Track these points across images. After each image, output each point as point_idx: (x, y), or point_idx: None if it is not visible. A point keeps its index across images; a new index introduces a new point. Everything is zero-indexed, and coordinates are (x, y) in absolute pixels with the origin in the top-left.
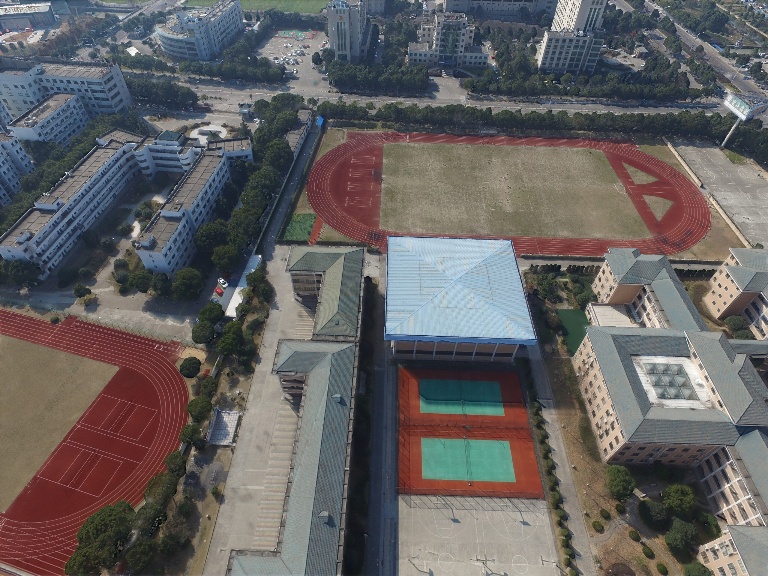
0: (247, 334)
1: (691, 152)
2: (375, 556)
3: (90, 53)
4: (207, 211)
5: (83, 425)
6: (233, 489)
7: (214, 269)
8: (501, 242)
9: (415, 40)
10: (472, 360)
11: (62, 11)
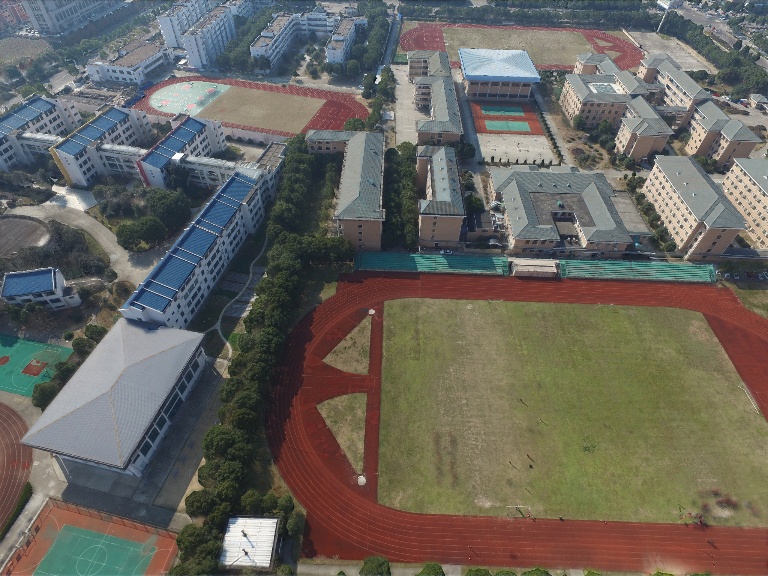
0: None
1: (637, 34)
2: None
3: None
4: None
5: (319, 114)
6: (400, 130)
7: None
8: (521, 51)
9: None
10: (507, 100)
11: None
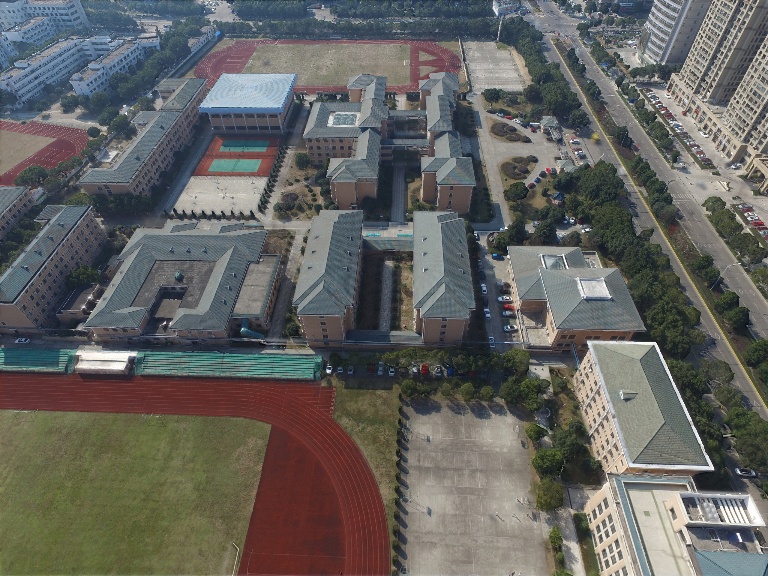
0: (133, 125)
1: (473, 44)
2: (170, 193)
3: None
4: None
5: (33, 157)
6: None
7: (123, 102)
8: (289, 74)
9: None
10: (259, 133)
11: None
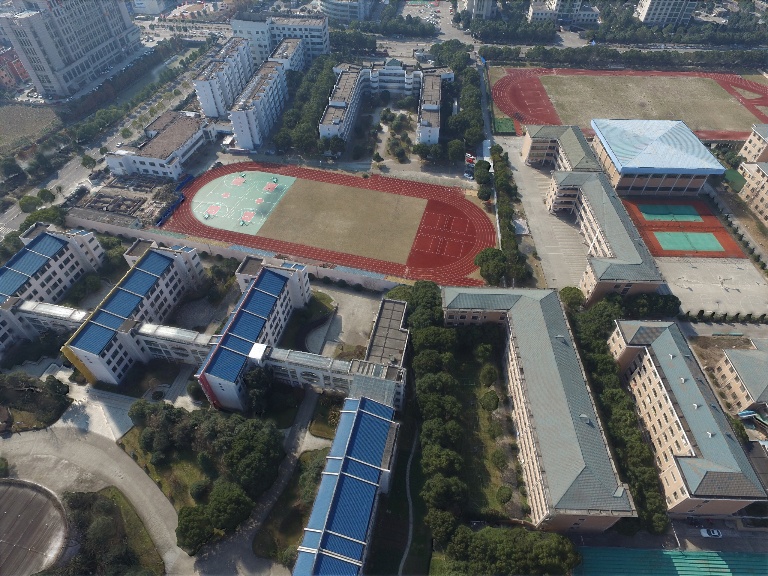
0: None
1: None
2: None
3: None
4: None
5: (425, 226)
6: (543, 254)
7: None
8: (675, 121)
9: (528, 5)
10: (669, 195)
11: None
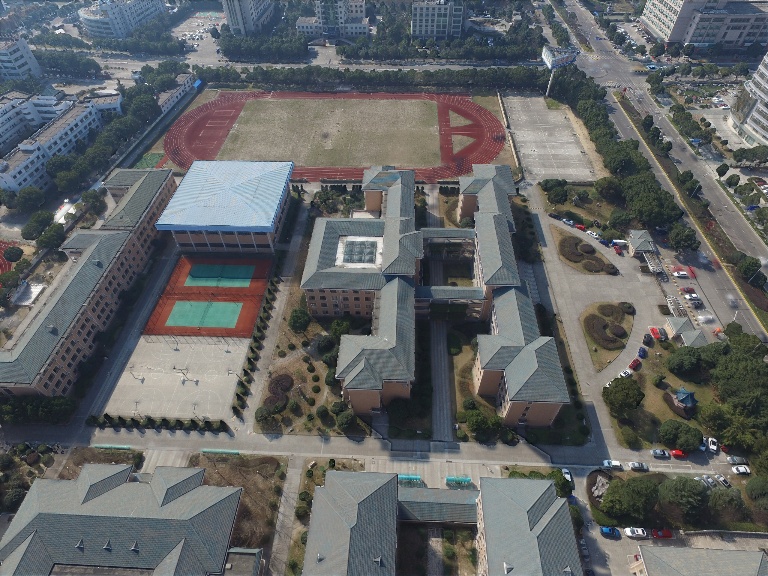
0: None
1: (516, 101)
2: (107, 370)
3: (22, 35)
4: (69, 150)
5: None
6: (21, 331)
7: (65, 193)
8: (284, 163)
9: (313, 16)
10: (241, 252)
11: (18, 3)
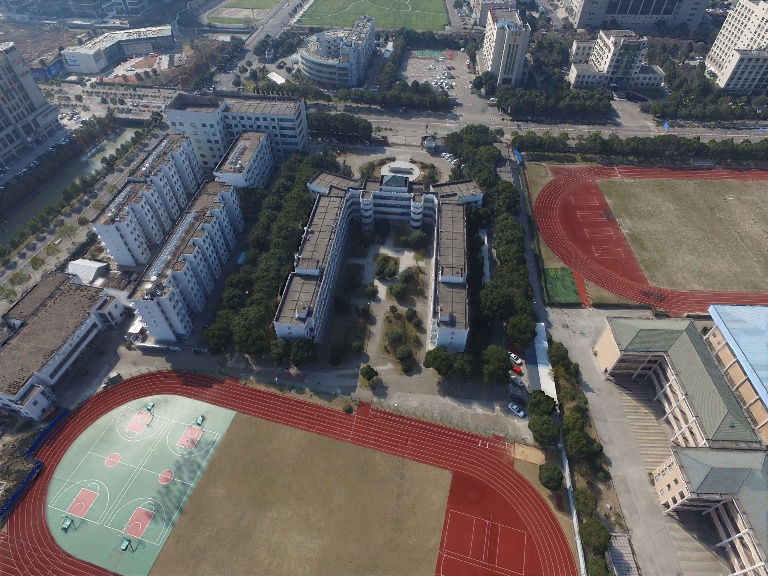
0: None
1: None
2: None
3: (235, 81)
4: None
5: (449, 553)
6: None
7: (493, 340)
8: None
9: (567, 59)
10: None
11: None
